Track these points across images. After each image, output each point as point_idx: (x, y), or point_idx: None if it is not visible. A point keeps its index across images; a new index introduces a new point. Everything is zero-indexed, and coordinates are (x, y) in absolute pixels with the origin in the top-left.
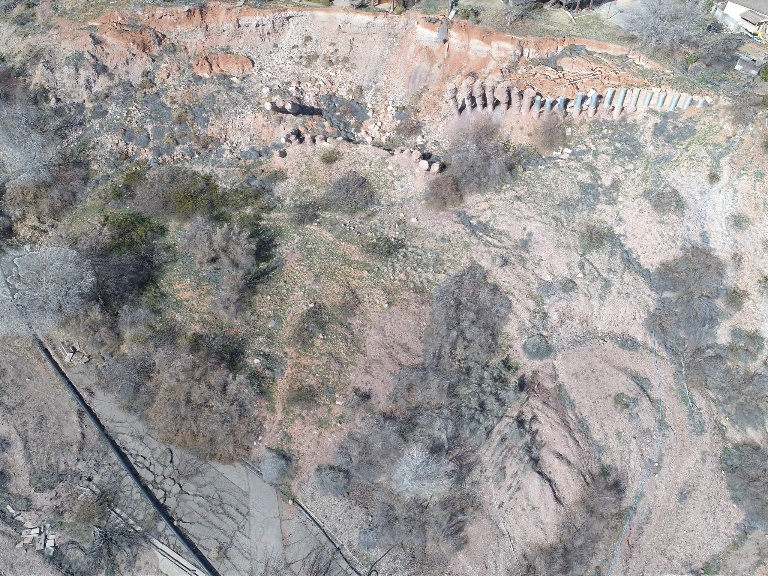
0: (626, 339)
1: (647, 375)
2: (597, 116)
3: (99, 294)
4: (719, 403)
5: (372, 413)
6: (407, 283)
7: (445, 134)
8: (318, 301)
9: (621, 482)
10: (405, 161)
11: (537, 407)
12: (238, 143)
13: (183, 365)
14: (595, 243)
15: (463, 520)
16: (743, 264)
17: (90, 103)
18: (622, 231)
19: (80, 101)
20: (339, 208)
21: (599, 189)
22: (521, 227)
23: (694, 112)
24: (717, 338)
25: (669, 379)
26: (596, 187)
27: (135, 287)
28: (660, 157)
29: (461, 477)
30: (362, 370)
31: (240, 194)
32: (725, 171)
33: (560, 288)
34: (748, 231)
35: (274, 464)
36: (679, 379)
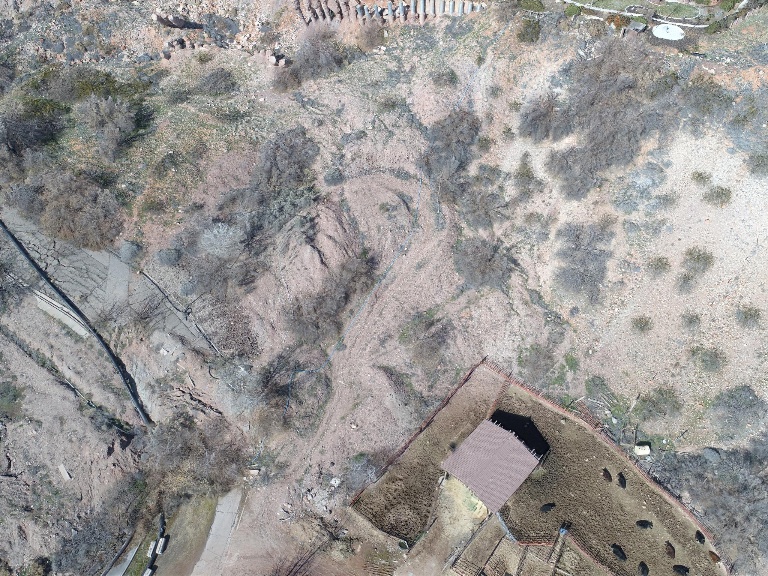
0: (401, 173)
1: (411, 194)
2: (407, 22)
3: (9, 141)
4: (462, 213)
5: (203, 216)
6: (245, 138)
7: (297, 41)
8: (177, 150)
9: (376, 258)
10: (260, 59)
11: (321, 210)
12: (135, 50)
13: (62, 178)
14: (388, 108)
15: (255, 276)
16: (494, 120)
17: (18, 20)
18: (411, 101)
19: (10, 18)
20: (206, 93)
21: (401, 74)
22: (337, 100)
23: (474, 15)
24: (469, 172)
25: (427, 197)
26: (399, 73)
27: (39, 141)
28: (446, 48)
29: (259, 252)
30: (201, 191)
31: (133, 87)
32: (489, 56)
33: (355, 137)
34: (501, 98)
35: (128, 248)
36: (434, 197)
